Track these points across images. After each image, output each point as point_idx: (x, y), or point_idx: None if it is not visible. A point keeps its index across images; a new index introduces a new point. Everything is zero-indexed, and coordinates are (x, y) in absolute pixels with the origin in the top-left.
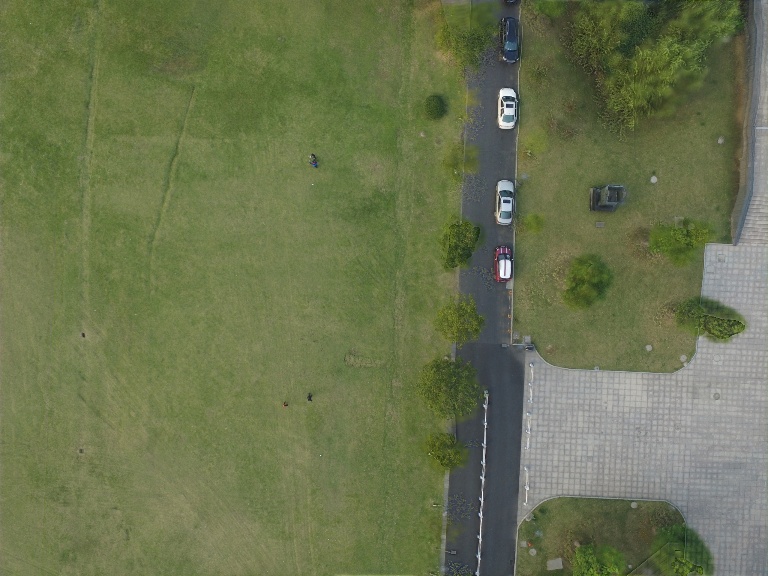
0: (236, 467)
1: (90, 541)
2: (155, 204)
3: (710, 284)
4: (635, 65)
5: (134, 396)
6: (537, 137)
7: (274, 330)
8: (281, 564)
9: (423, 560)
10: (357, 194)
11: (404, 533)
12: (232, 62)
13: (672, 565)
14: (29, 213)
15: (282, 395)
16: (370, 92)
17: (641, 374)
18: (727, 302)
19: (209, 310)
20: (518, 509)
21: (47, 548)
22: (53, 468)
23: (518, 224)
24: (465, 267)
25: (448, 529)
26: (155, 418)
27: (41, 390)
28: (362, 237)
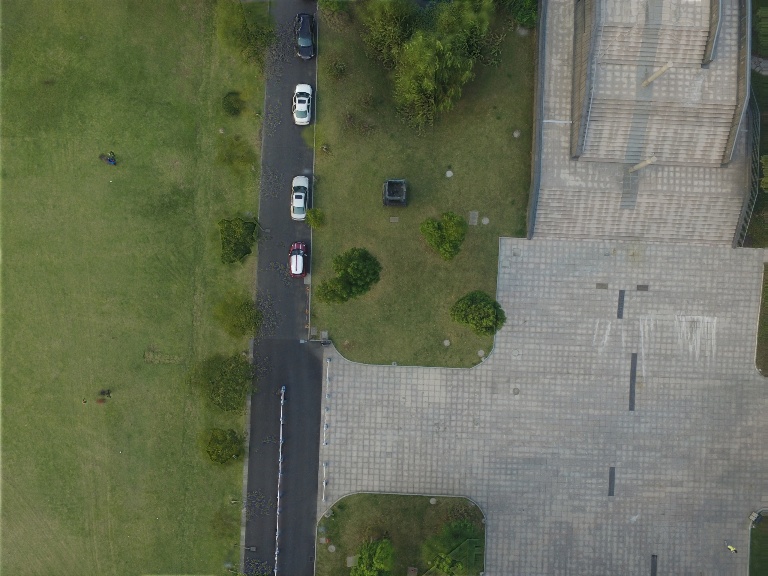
0: (36, 464)
1: None
2: None
3: (506, 278)
4: (436, 60)
5: None
6: (333, 133)
7: (73, 327)
8: (81, 561)
9: (223, 557)
10: (156, 191)
11: (204, 530)
12: (35, 61)
13: (434, 560)
14: None
15: (81, 392)
16: (171, 89)
17: (439, 369)
18: (523, 296)
19: (9, 307)
20: (317, 505)
21: None
22: None
23: (315, 220)
24: (262, 263)
25: (247, 525)
26: None
27: None
28: (161, 234)
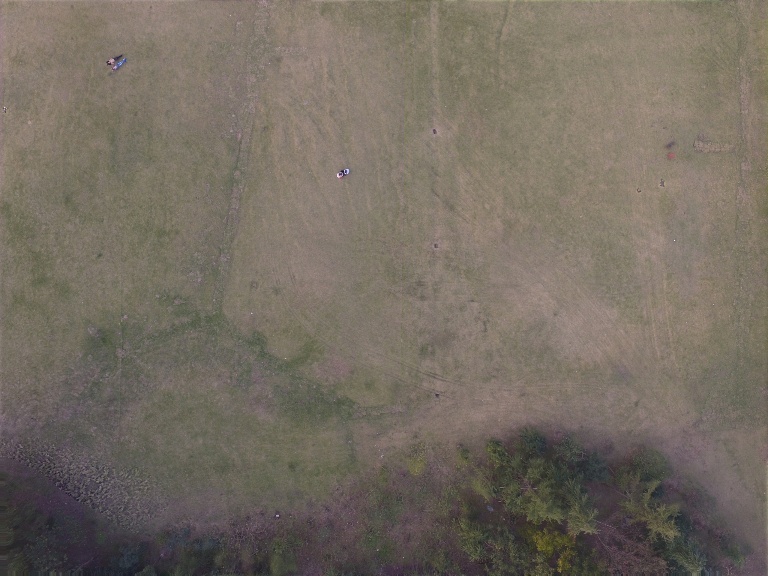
0: (592, 254)
1: (448, 334)
2: None
3: None
4: None
5: (487, 189)
6: None
7: (624, 118)
8: (640, 349)
9: None
10: None
11: (760, 314)
12: None
13: None
14: (379, 13)
15: (635, 182)
16: None
17: None
18: None
19: (559, 101)
20: None
21: (406, 343)
22: (409, 263)
23: None
24: None
25: None
26: (509, 209)
27: (395, 186)
28: (705, 25)
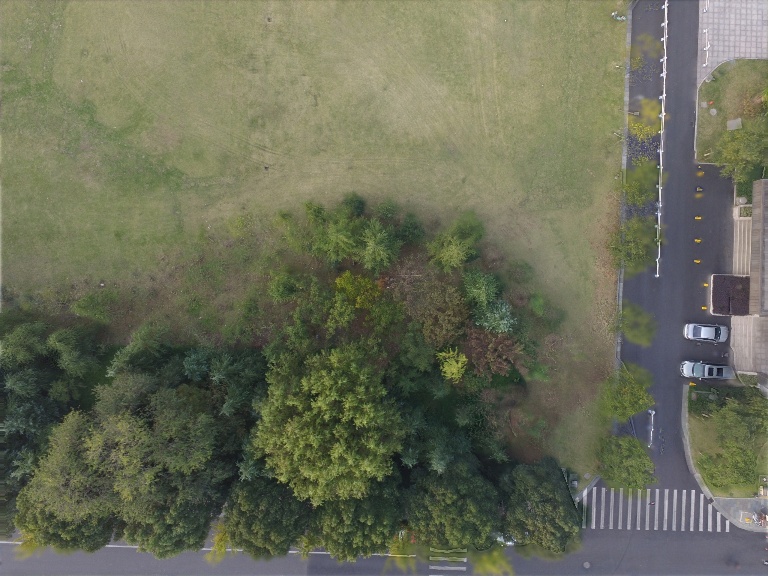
0: (423, 31)
1: (279, 107)
2: None
3: None
4: None
5: None
6: None
7: None
8: (469, 126)
9: (607, 122)
10: None
11: (588, 96)
12: None
13: None
14: None
15: None
16: None
17: None
18: None
19: None
20: (697, 72)
21: (236, 114)
22: (242, 36)
23: None
24: None
25: (631, 91)
26: None
27: None
28: None
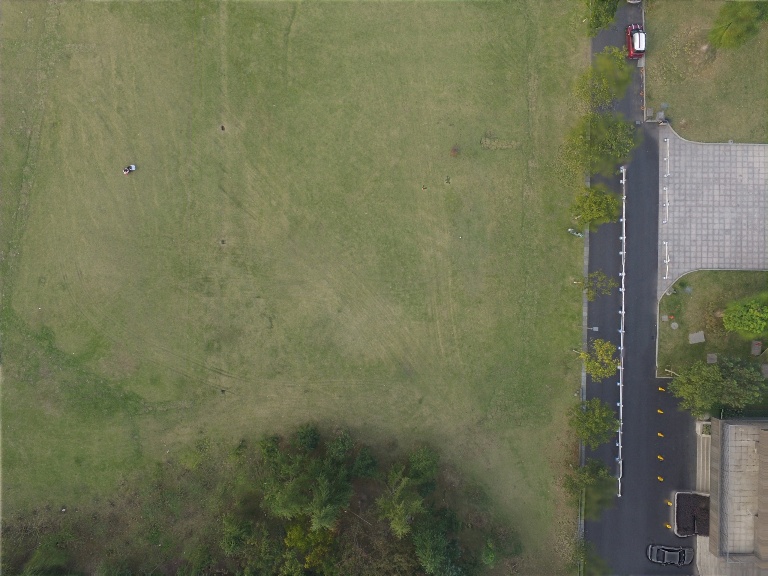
0: (377, 251)
1: (234, 330)
2: None
3: None
4: None
5: (274, 185)
6: None
7: (411, 115)
8: (425, 346)
9: (565, 338)
10: None
11: (545, 311)
12: None
13: None
14: (168, 10)
15: (420, 179)
16: None
17: None
18: None
19: (346, 98)
20: (658, 284)
21: (192, 338)
22: (196, 259)
23: (647, 4)
24: (596, 47)
25: (589, 306)
26: (296, 206)
27: (183, 183)
28: (493, 22)
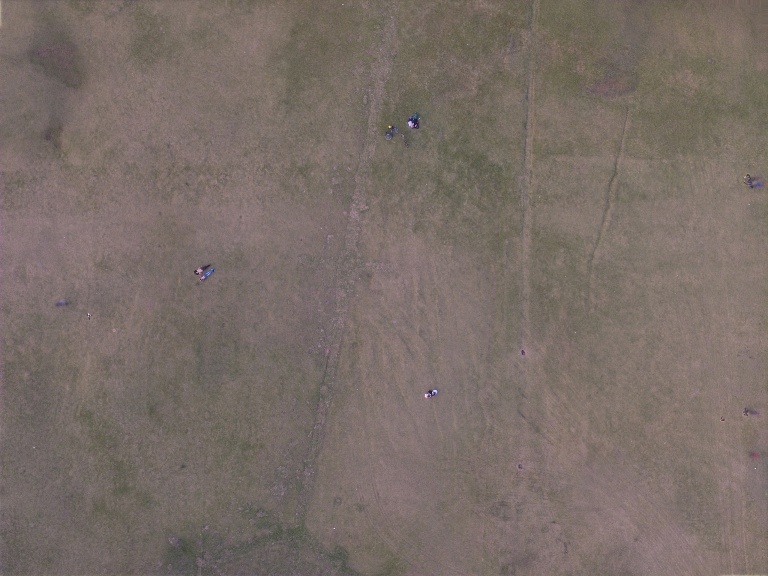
0: (674, 481)
1: (529, 554)
2: (596, 223)
3: None
4: None
5: (573, 412)
6: None
7: (712, 347)
8: (717, 574)
9: None
10: None
11: None
12: (663, 83)
13: None
14: (472, 232)
15: (719, 410)
16: None
17: None
18: None
19: (648, 327)
20: None
21: (487, 562)
22: (493, 483)
23: None
24: None
25: None
26: (594, 433)
27: (482, 407)
28: None
